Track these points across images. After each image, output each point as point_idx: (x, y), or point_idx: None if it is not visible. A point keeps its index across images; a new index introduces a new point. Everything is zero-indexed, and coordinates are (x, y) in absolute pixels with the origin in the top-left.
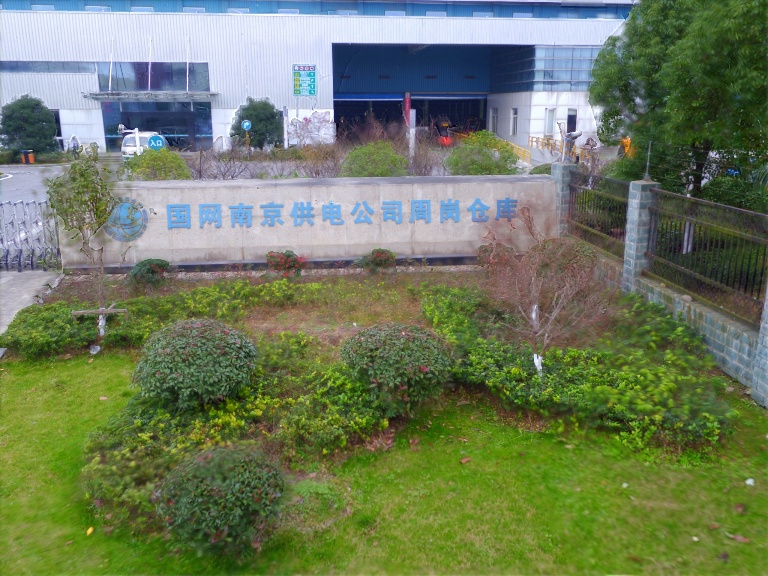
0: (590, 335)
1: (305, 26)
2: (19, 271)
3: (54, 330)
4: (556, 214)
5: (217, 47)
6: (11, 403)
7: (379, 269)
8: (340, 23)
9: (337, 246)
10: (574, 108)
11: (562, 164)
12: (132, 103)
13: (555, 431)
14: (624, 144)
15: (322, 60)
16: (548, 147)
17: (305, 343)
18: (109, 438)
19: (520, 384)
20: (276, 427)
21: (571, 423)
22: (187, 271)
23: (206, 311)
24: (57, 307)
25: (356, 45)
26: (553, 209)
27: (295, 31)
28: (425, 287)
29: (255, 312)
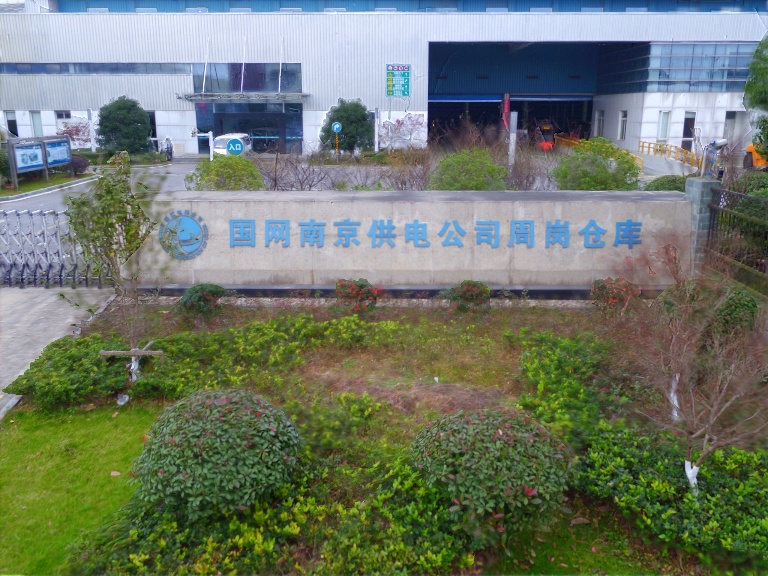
0: (757, 423)
1: (401, 24)
2: (73, 288)
3: (77, 374)
4: (690, 241)
5: (311, 47)
6: (7, 473)
7: (469, 306)
8: (438, 21)
9: (421, 272)
10: (692, 110)
11: (701, 180)
12: (225, 104)
13: None
14: None
15: (418, 60)
16: None
17: (370, 412)
18: (91, 558)
19: (668, 511)
20: (317, 553)
21: None
22: (249, 296)
23: (257, 355)
24: (90, 341)
25: (454, 44)
26: (687, 235)
27: (391, 30)
28: (526, 334)
29: (317, 355)
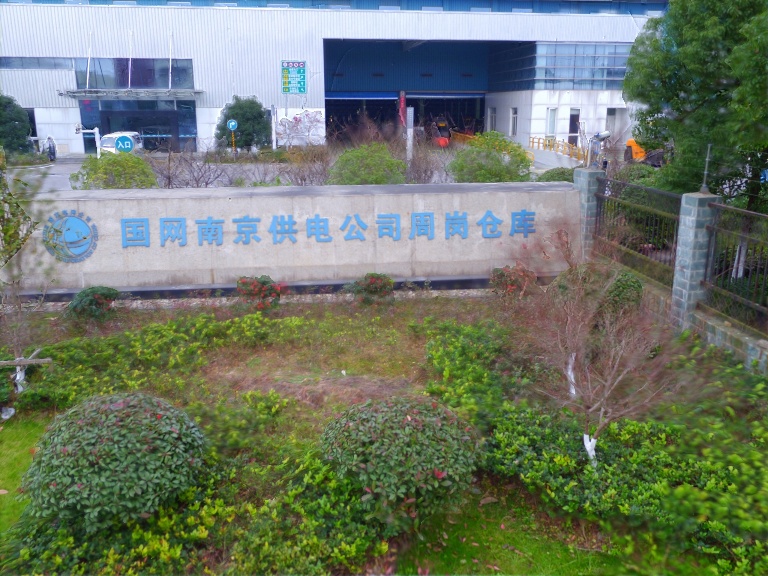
0: (647, 395)
1: (295, 20)
2: None
3: None
4: (580, 228)
5: (202, 42)
6: None
7: (374, 298)
8: (332, 17)
9: (324, 267)
10: (577, 107)
11: (588, 170)
12: (112, 101)
13: (621, 552)
14: (665, 147)
15: (313, 56)
16: (550, 148)
17: (277, 409)
18: None
19: (570, 483)
20: (227, 555)
21: (644, 542)
22: (145, 298)
23: (156, 358)
24: None
25: (348, 41)
26: (576, 223)
27: (284, 26)
28: (430, 323)
29: (221, 355)
